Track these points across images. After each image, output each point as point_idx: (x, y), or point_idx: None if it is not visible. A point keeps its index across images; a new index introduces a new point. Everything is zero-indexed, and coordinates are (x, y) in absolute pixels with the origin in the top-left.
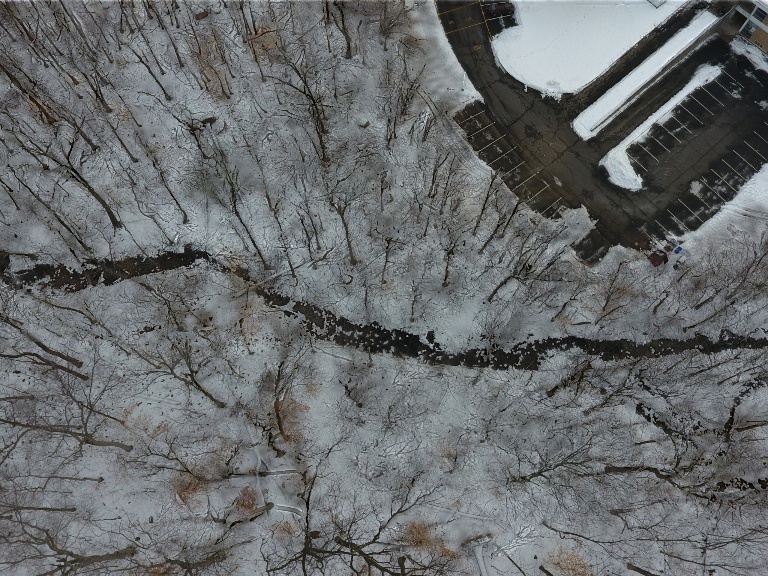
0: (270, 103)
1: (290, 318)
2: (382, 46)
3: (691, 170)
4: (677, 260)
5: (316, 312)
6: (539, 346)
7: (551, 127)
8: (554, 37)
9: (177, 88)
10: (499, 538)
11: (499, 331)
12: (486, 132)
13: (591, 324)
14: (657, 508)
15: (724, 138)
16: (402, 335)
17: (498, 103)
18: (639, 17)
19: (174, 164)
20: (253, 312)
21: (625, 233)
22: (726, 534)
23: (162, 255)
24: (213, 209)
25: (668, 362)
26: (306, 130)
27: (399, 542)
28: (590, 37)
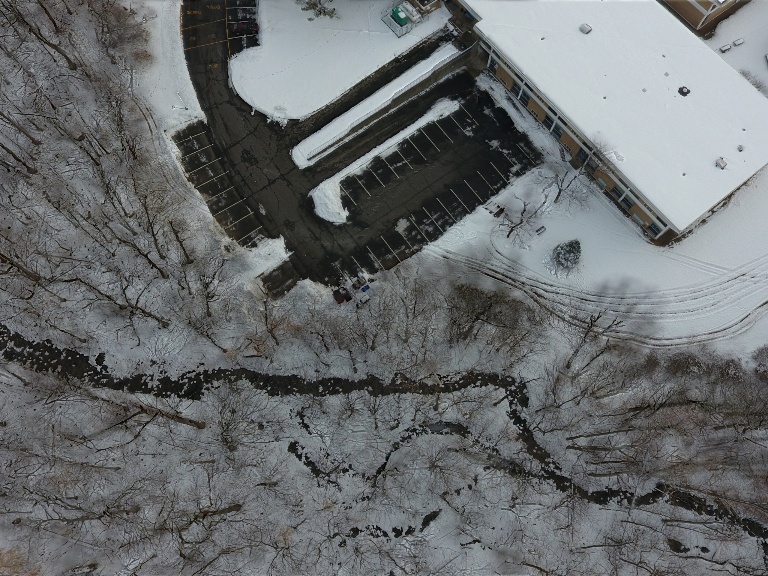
0: None
1: None
2: (109, 59)
3: (402, 207)
4: (361, 299)
5: None
6: (207, 376)
7: (269, 153)
8: (293, 60)
9: None
10: (105, 568)
11: (170, 358)
12: (202, 154)
13: (262, 358)
14: (243, 553)
15: (445, 176)
16: (72, 355)
17: (221, 125)
18: (380, 46)
19: None
20: None
21: (317, 267)
22: None
23: None
24: None
25: (329, 402)
26: (18, 140)
27: None
28: (328, 63)
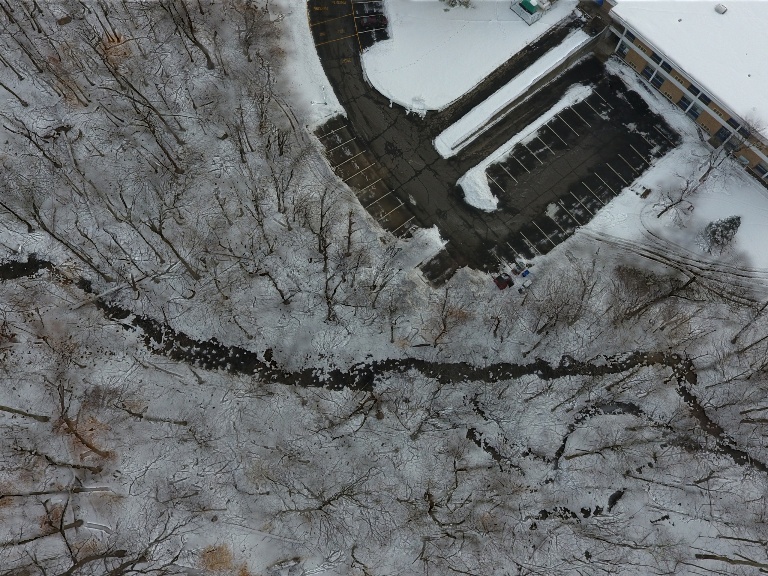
0: (127, 112)
1: (128, 332)
2: (246, 57)
3: (549, 192)
4: (523, 284)
5: (155, 326)
6: (377, 367)
7: (412, 144)
8: (425, 52)
9: (33, 94)
10: (307, 562)
11: (338, 351)
12: (345, 147)
13: (430, 346)
14: (457, 538)
15: (587, 160)
16: (240, 352)
17: (361, 118)
18: (511, 34)
19: (24, 172)
20: (90, 325)
21: (474, 255)
22: (540, 563)
23: (5, 264)
24: (60, 219)
25: (503, 387)
26: (162, 141)
27: (192, 565)
28: (460, 53)
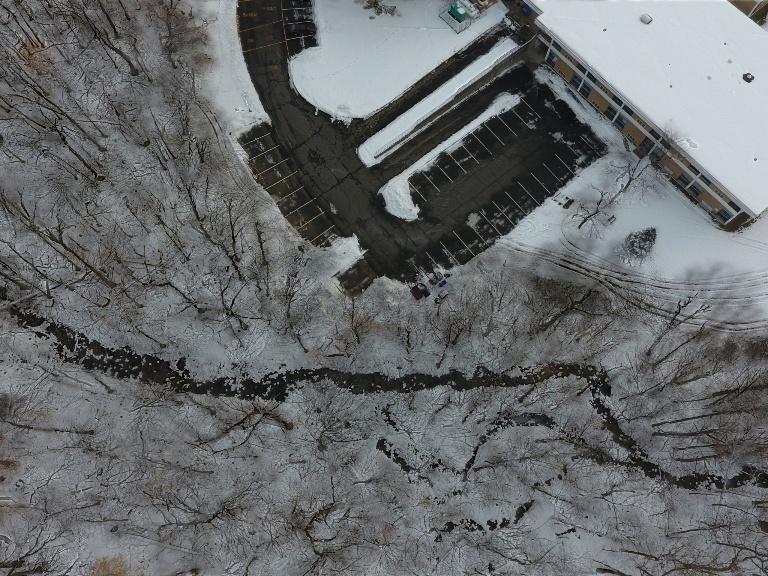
0: (49, 118)
1: (41, 339)
2: (171, 63)
3: (471, 201)
4: (439, 294)
5: (69, 334)
6: (290, 377)
7: (336, 152)
8: (353, 59)
9: None
10: (206, 573)
11: (251, 360)
12: (268, 155)
13: (344, 356)
14: (351, 551)
15: (511, 169)
16: (153, 361)
17: (285, 126)
18: (439, 42)
19: None
20: (2, 332)
21: (393, 264)
22: (442, 575)
23: None
24: None
25: (415, 398)
26: (83, 147)
27: None
28: (388, 61)
